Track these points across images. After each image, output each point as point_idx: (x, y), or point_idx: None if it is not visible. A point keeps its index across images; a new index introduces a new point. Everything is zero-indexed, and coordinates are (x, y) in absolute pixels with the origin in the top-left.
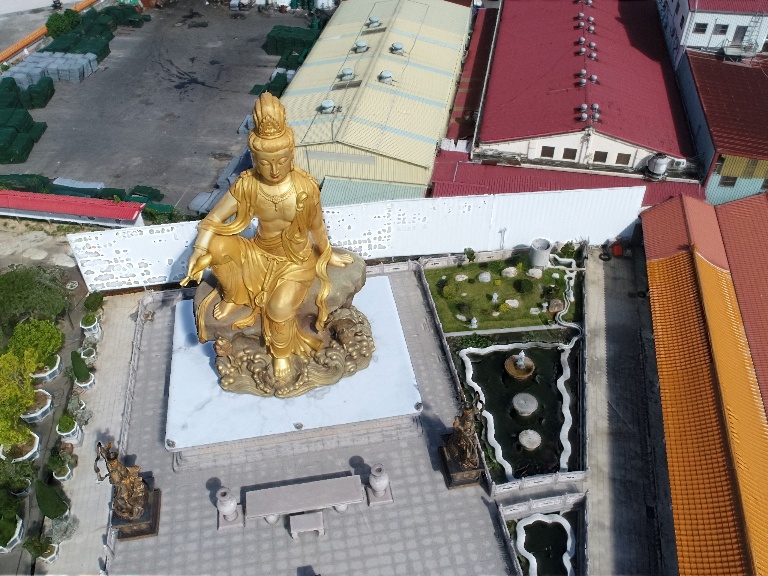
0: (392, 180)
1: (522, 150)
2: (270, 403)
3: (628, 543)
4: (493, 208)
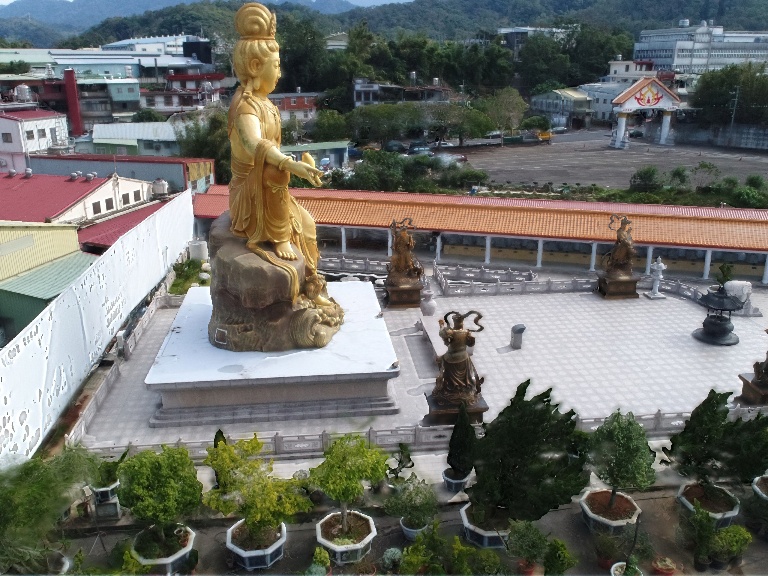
0: (52, 258)
1: (83, 212)
2: (348, 328)
3: None
4: (156, 228)
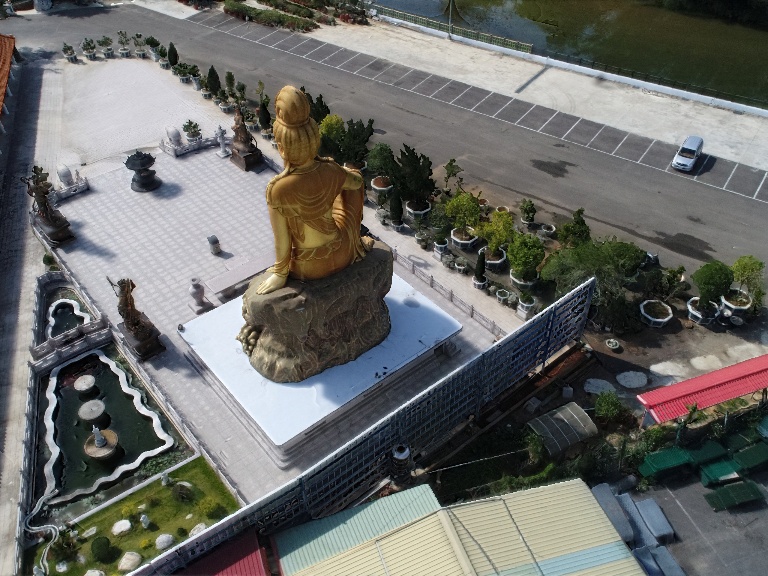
0: None
1: None
2: None
3: (3, 346)
4: None
